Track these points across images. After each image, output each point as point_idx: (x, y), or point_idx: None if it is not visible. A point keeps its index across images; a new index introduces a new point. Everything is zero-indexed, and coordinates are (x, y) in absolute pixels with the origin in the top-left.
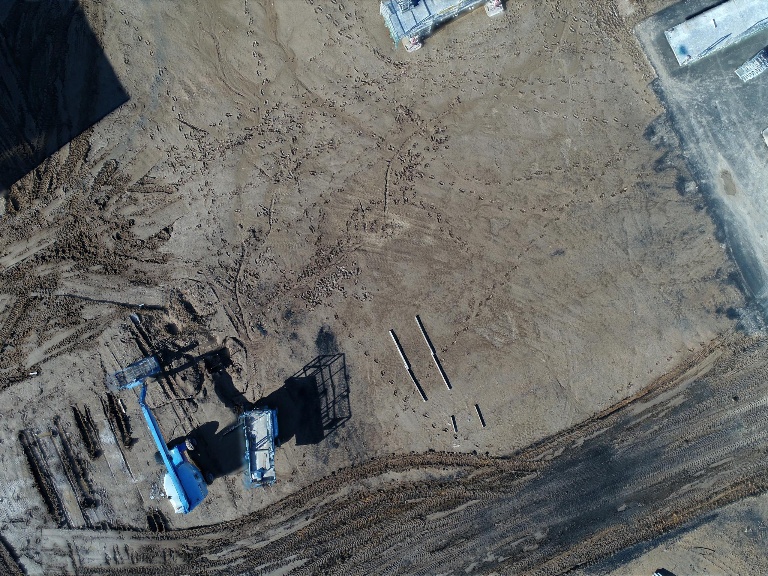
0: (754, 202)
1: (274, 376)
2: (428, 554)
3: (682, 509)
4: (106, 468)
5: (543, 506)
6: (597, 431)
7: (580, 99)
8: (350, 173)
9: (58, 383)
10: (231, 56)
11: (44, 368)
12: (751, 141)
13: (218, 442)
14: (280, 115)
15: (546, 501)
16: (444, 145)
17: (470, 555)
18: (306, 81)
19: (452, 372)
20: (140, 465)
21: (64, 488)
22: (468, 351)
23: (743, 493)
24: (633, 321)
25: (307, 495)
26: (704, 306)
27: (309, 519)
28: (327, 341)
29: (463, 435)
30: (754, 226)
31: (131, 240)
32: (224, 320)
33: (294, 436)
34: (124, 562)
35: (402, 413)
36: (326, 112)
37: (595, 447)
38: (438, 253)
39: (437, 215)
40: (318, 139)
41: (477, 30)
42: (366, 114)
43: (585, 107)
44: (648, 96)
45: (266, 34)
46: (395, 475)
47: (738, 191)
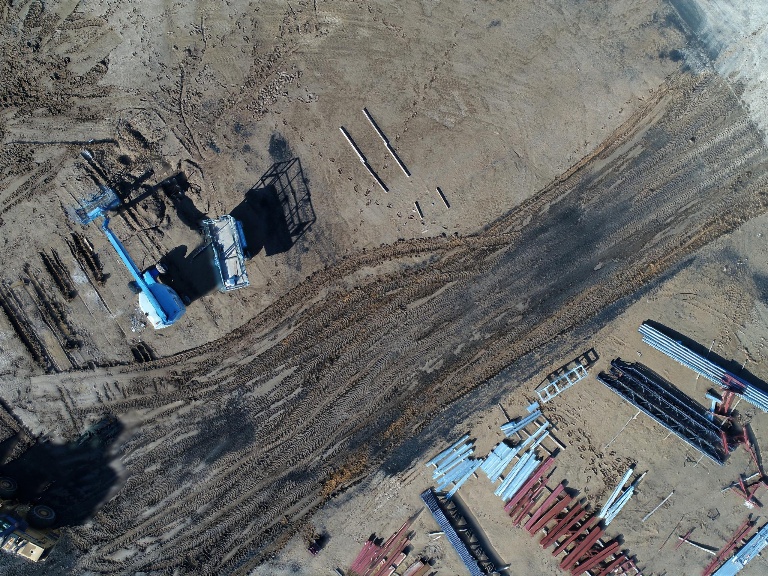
0: None
1: (233, 192)
2: (414, 343)
3: (658, 258)
4: (83, 308)
5: (520, 277)
6: (561, 194)
7: None
8: None
9: (22, 231)
10: None
11: (5, 218)
12: None
13: (189, 265)
14: None
15: (522, 272)
16: None
17: (456, 337)
18: None
19: (408, 159)
20: (116, 300)
21: (45, 334)
22: (421, 136)
23: (716, 232)
24: (579, 79)
25: (286, 304)
26: (646, 53)
27: (291, 327)
28: (280, 148)
29: (429, 219)
30: None
31: (70, 78)
32: (175, 144)
33: (263, 247)
34: (116, 398)
35: (366, 208)
36: None
37: (562, 210)
38: (375, 43)
39: (368, 6)
40: None
41: None
42: None
43: None
44: None
45: None
46: (369, 270)
47: None
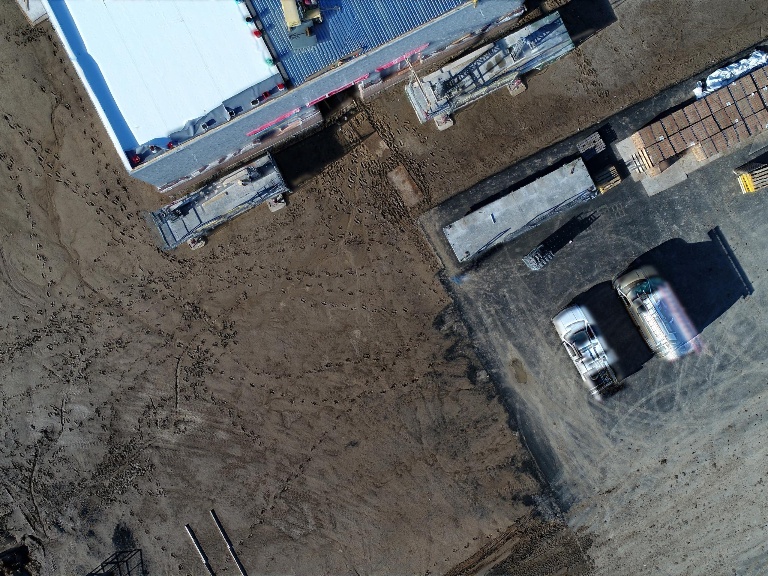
0: (546, 390)
1: (73, 573)
2: None
3: None
4: None
5: None
6: None
7: (368, 290)
8: (140, 371)
9: None
10: (15, 260)
11: None
12: (541, 329)
13: None
14: (67, 316)
15: None
16: (233, 340)
17: None
18: (91, 282)
19: (249, 564)
20: None
21: None
22: (265, 543)
23: None
24: (429, 510)
25: None
26: (500, 493)
27: None
28: (123, 537)
29: None
30: (547, 414)
31: None
32: (21, 519)
33: None
34: None
35: None
36: (113, 311)
37: None
38: (231, 447)
39: (229, 410)
40: (106, 338)
41: (261, 225)
42: (153, 312)
43: (373, 298)
44: (436, 286)
45: (49, 237)
46: None
47: (529, 379)
